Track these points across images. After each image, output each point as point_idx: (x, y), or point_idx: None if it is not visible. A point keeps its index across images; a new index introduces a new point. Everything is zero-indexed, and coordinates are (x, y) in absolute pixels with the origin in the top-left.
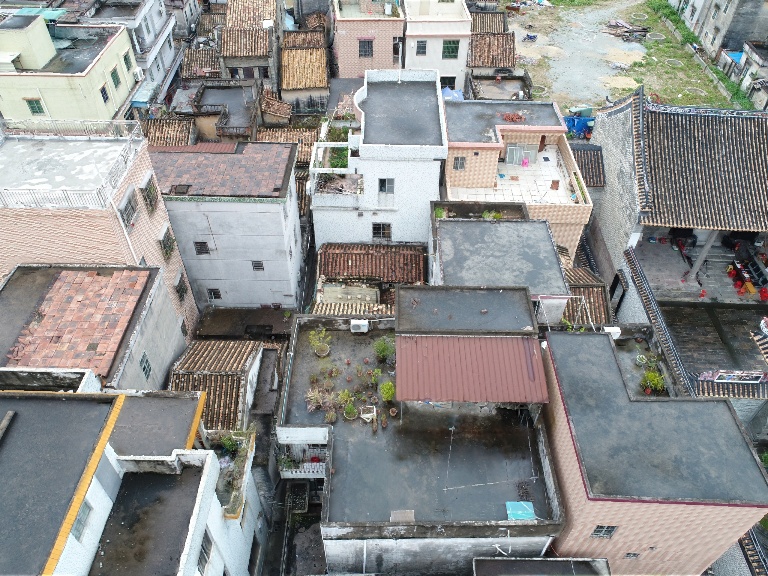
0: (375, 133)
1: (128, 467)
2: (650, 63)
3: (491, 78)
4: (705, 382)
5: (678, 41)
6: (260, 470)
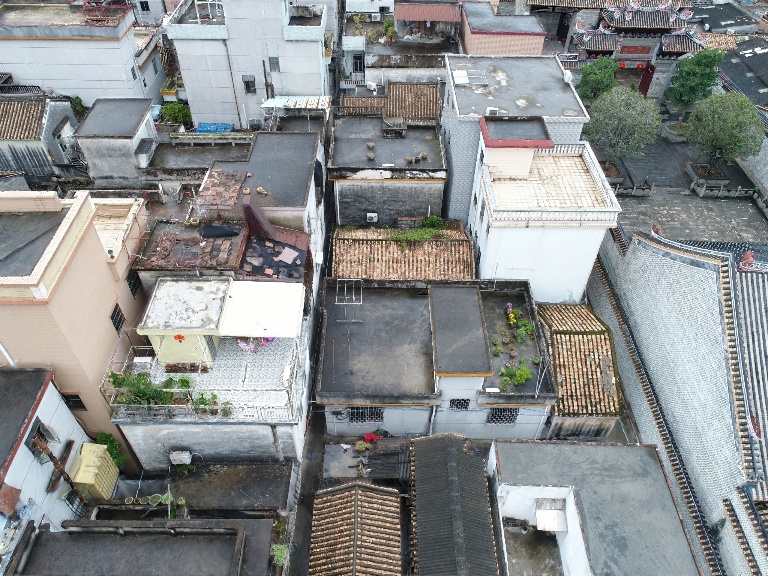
0: None
1: (293, 12)
2: None
3: None
4: None
5: None
6: (332, 75)
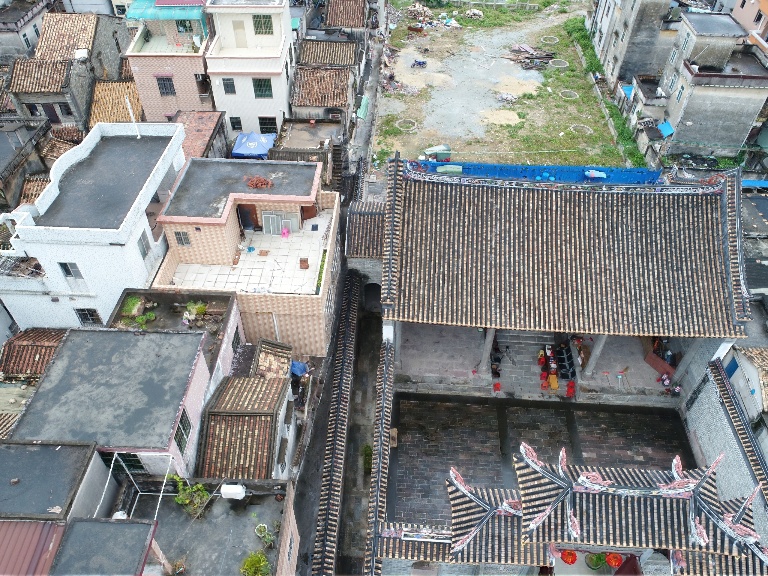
0: (63, 206)
1: None
2: (542, 95)
3: (307, 121)
4: (391, 539)
5: (582, 69)
6: None
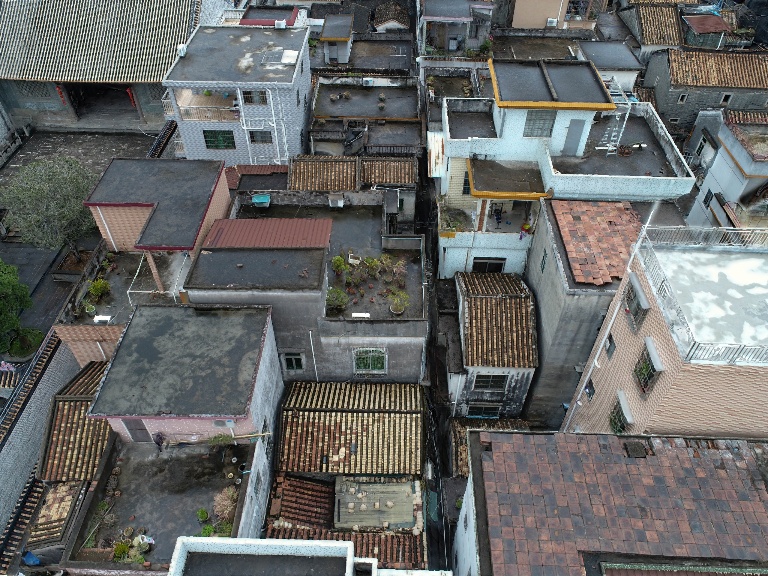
0: None
1: None
2: None
3: None
4: None
5: None
6: None
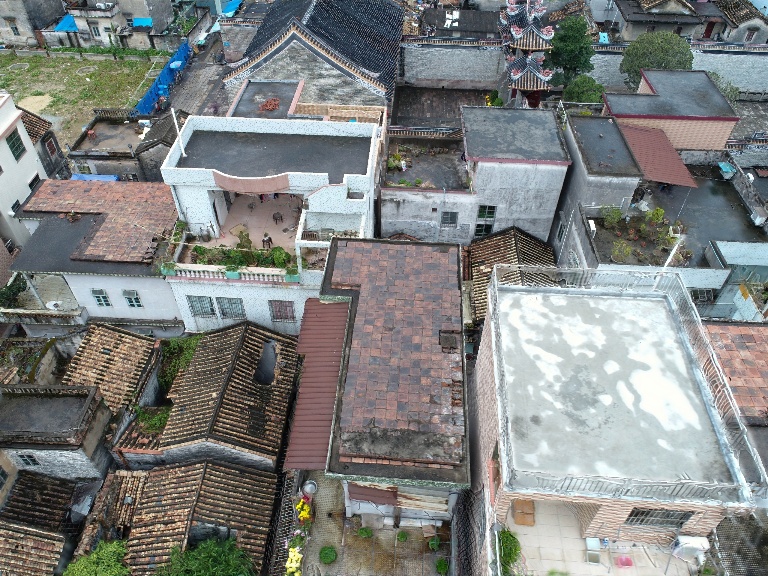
0: None
1: None
2: (8, 79)
3: (81, 140)
4: None
5: None
6: None
